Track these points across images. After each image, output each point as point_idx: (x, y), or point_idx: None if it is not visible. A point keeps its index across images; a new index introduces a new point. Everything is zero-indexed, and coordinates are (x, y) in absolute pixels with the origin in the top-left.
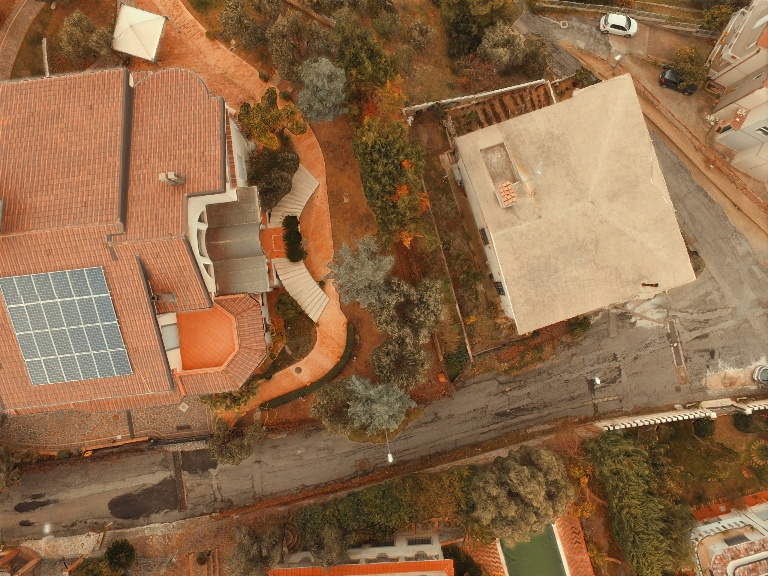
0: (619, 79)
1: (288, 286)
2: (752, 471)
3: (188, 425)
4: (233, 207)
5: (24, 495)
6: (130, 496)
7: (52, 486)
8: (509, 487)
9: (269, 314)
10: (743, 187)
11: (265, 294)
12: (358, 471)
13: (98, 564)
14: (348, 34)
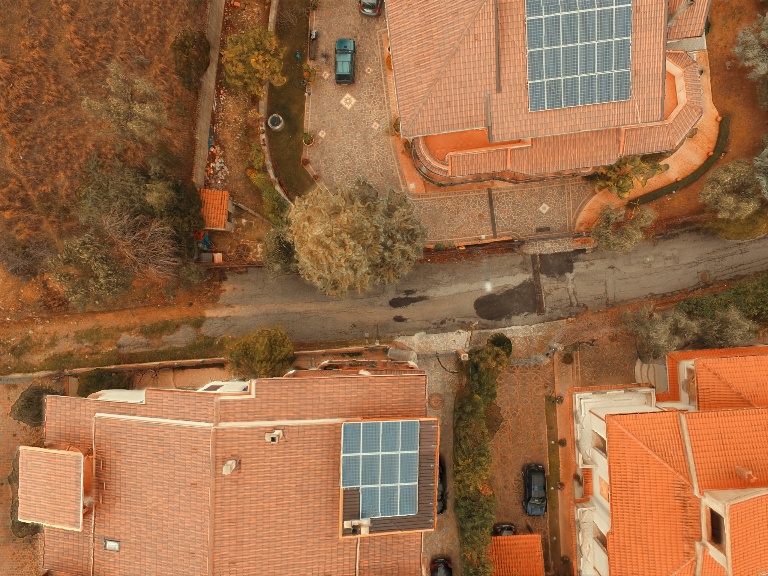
0: None
1: None
2: None
3: (548, 227)
4: None
5: (397, 290)
6: (493, 297)
7: (423, 283)
8: None
9: None
10: None
11: None
12: (700, 283)
13: (493, 348)
14: None
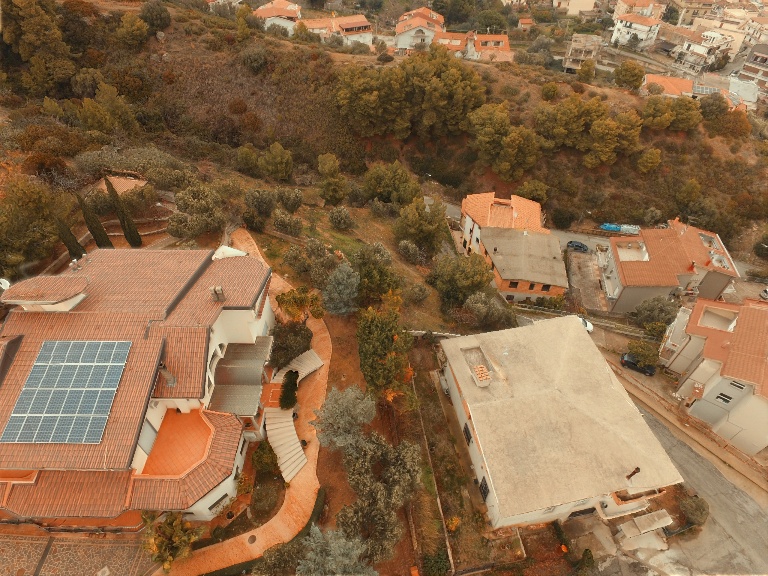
0: (568, 317)
1: (271, 437)
2: None
3: None
4: (249, 348)
5: None
6: None
7: None
8: None
9: (243, 468)
10: (724, 444)
11: (246, 447)
12: None
13: None
14: (367, 260)
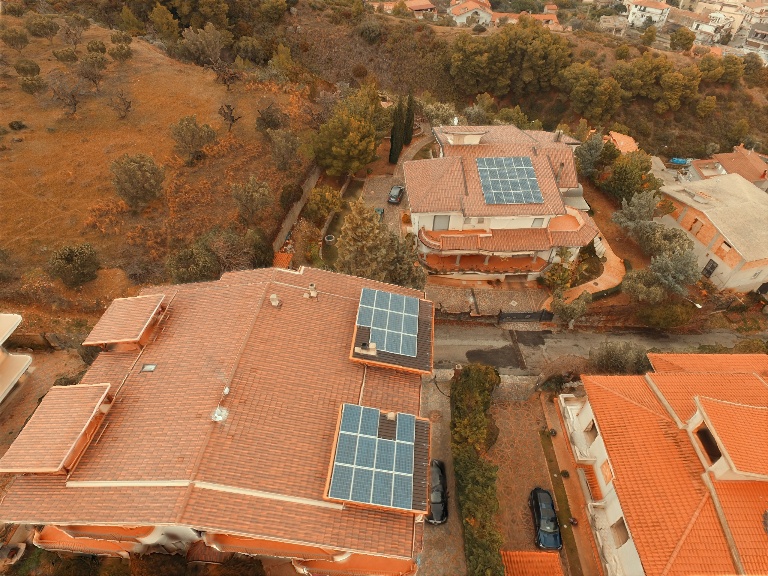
0: (732, 174)
1: None
2: None
3: None
4: None
5: None
6: (482, 352)
7: None
8: None
9: None
10: None
11: None
12: None
13: None
14: None
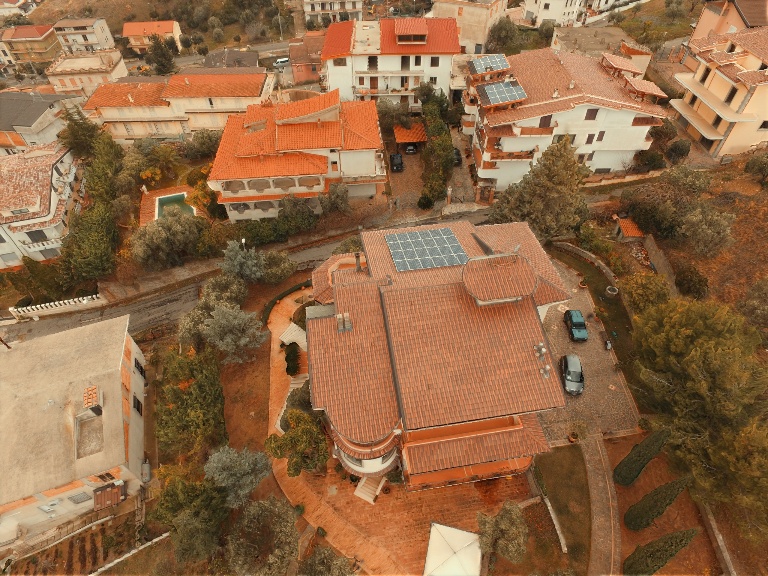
0: None
1: None
2: (5, 282)
3: None
4: None
5: None
6: None
7: None
8: (170, 232)
9: None
10: None
11: None
12: None
13: (433, 195)
14: None
